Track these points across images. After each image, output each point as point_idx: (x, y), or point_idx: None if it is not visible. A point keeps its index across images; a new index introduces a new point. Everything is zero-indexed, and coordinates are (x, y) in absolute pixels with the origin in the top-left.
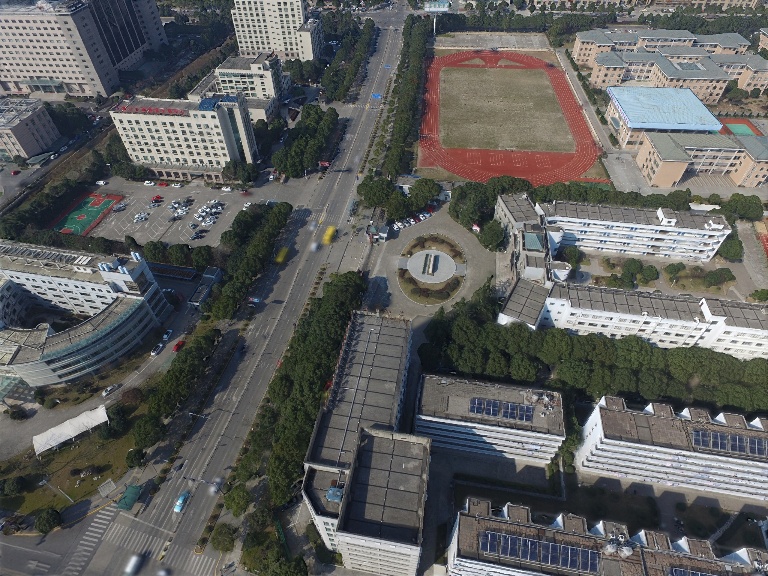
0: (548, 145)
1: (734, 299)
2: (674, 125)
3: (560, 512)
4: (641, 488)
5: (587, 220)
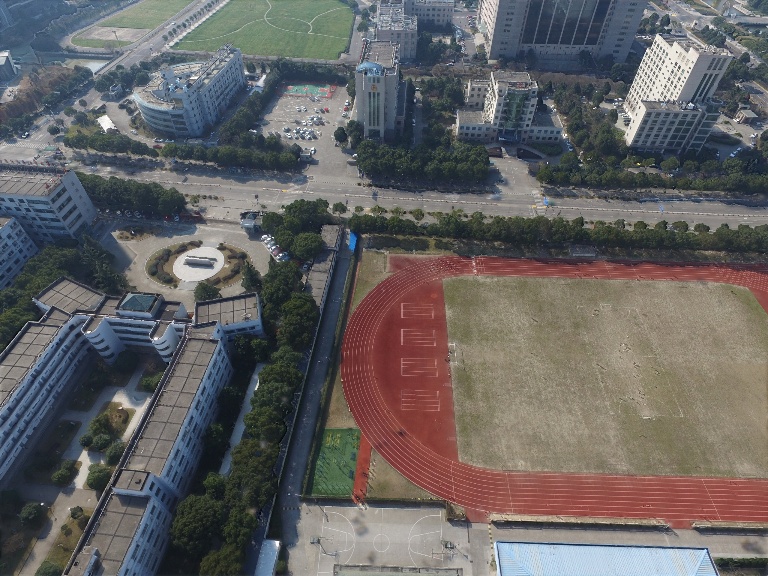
0: (479, 418)
1: None
2: None
3: None
4: None
5: (167, 370)
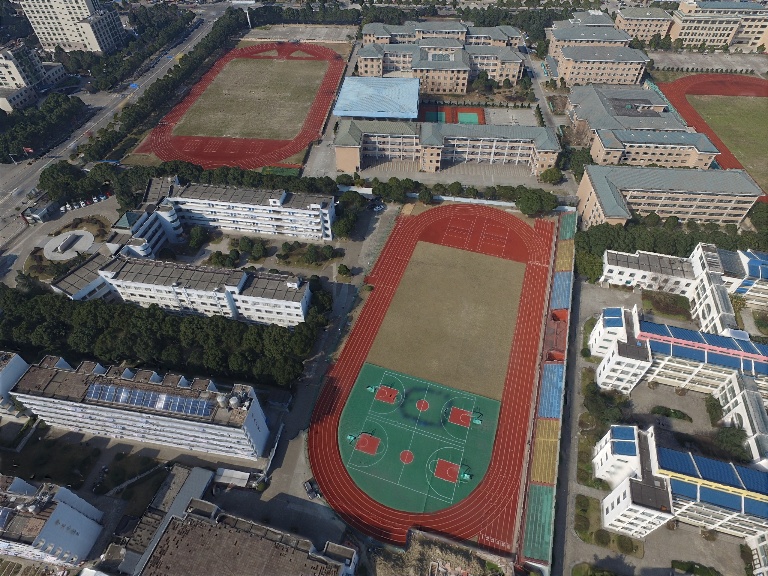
0: (273, 133)
1: (327, 274)
2: (373, 113)
3: (7, 462)
4: (98, 441)
5: (203, 201)
